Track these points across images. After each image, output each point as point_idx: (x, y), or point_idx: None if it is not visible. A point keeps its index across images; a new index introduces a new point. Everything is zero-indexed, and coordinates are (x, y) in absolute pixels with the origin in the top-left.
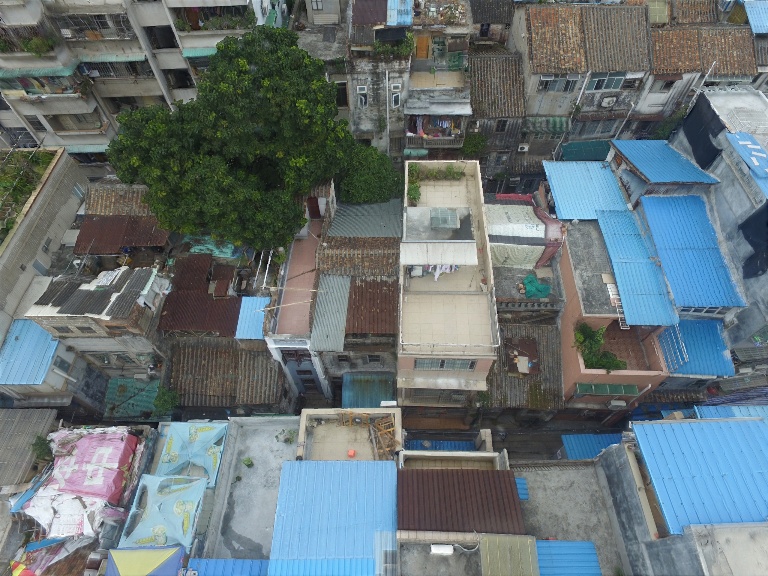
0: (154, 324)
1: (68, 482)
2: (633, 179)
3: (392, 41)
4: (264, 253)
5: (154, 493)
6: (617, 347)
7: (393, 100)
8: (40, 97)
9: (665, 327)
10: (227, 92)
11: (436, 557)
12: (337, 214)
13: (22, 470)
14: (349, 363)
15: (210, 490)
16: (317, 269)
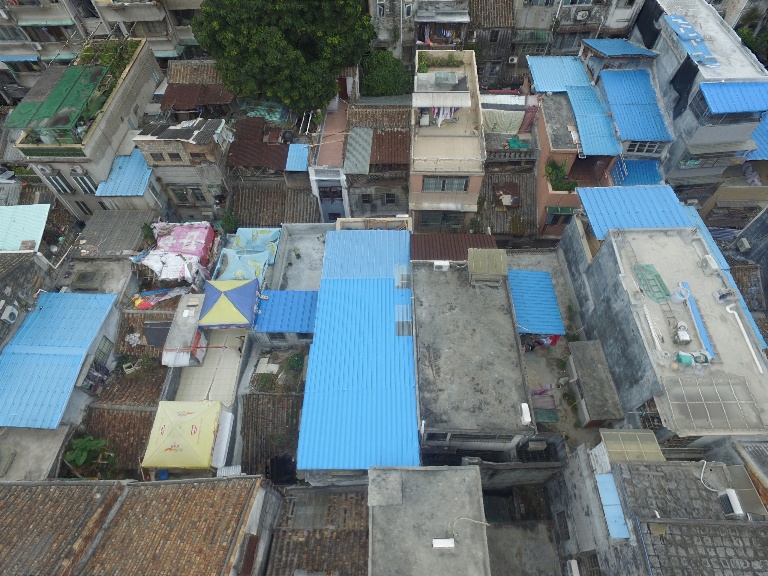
0: (223, 160)
1: (171, 247)
2: (595, 61)
3: None
4: (304, 120)
5: None
6: (579, 184)
7: (406, 10)
8: (123, 4)
9: (614, 160)
10: None
11: (437, 272)
12: (360, 99)
13: (136, 243)
14: (370, 204)
15: (270, 268)
16: (348, 121)
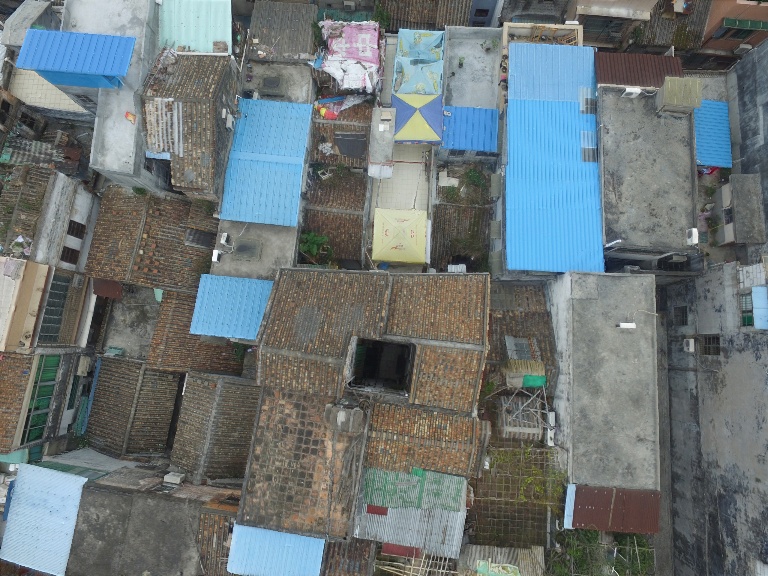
0: None
1: (348, 53)
2: None
3: None
4: None
5: None
6: None
7: None
8: None
9: None
10: None
11: (625, 99)
12: None
13: (309, 45)
14: (526, 1)
15: None
16: None
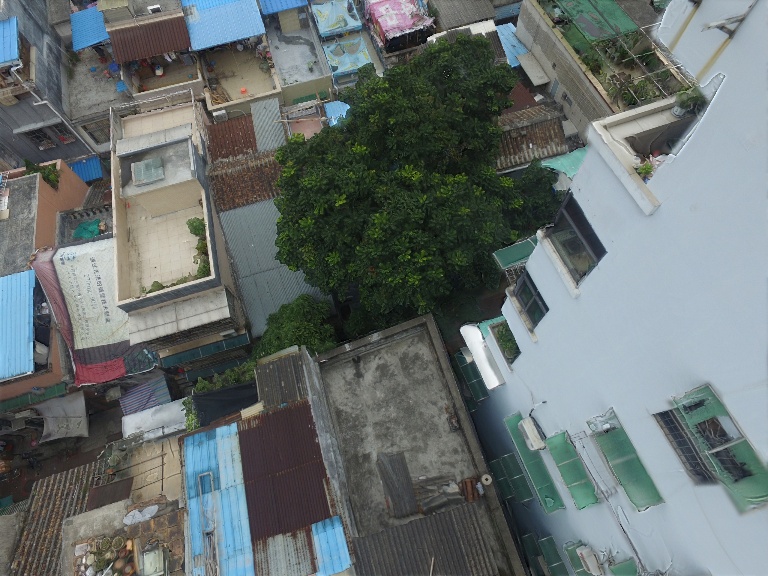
0: None
1: (398, 2)
2: None
3: None
4: None
5: (345, 15)
6: None
7: None
8: None
9: None
10: None
11: None
12: None
13: (433, 1)
14: None
15: None
16: None
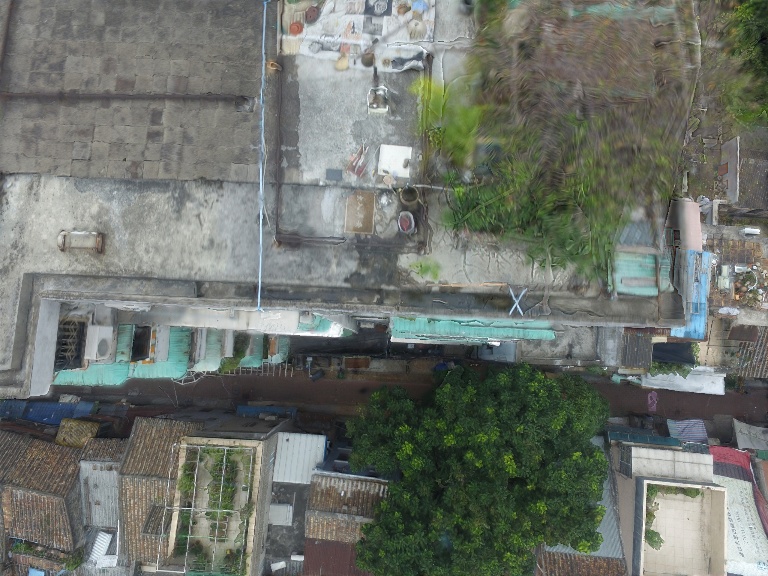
0: None
1: None
2: None
3: (673, 362)
4: None
5: None
6: None
7: None
8: None
9: None
10: (515, 566)
11: None
12: None
13: None
14: None
15: None
16: None
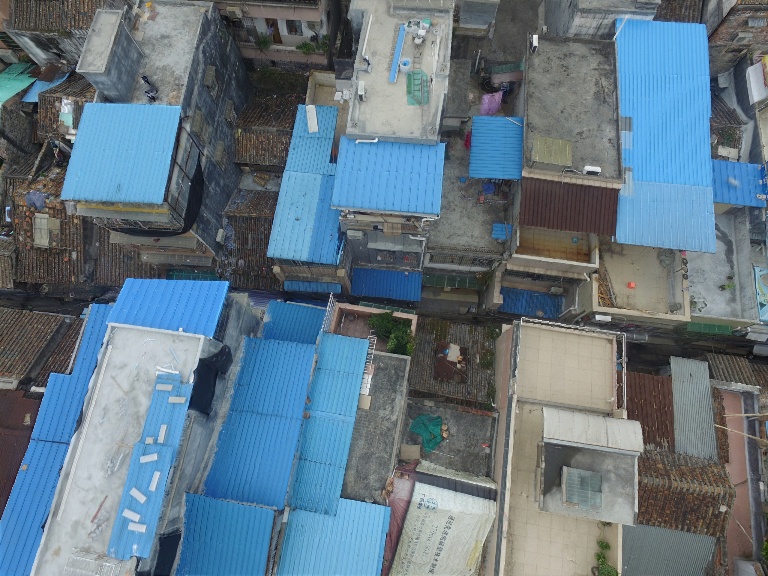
0: None
1: None
2: None
3: None
4: None
5: None
6: None
7: None
8: None
9: None
10: None
11: None
12: None
13: None
14: None
15: None
16: None
